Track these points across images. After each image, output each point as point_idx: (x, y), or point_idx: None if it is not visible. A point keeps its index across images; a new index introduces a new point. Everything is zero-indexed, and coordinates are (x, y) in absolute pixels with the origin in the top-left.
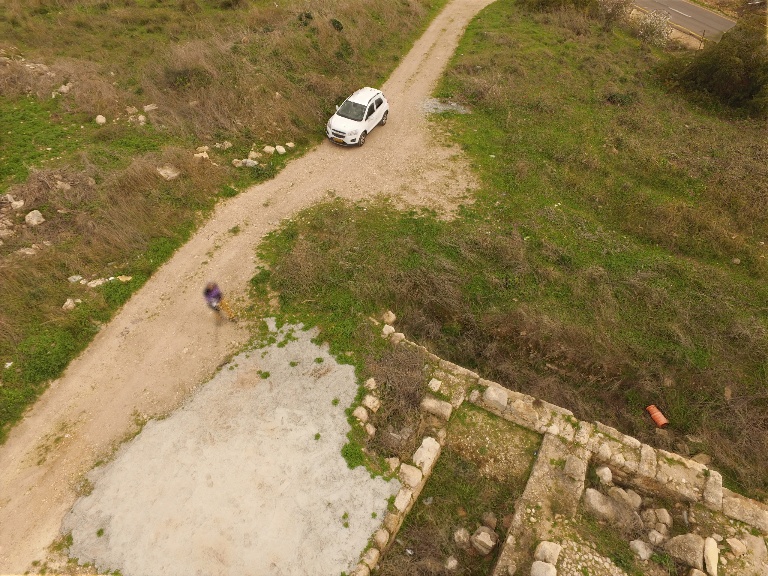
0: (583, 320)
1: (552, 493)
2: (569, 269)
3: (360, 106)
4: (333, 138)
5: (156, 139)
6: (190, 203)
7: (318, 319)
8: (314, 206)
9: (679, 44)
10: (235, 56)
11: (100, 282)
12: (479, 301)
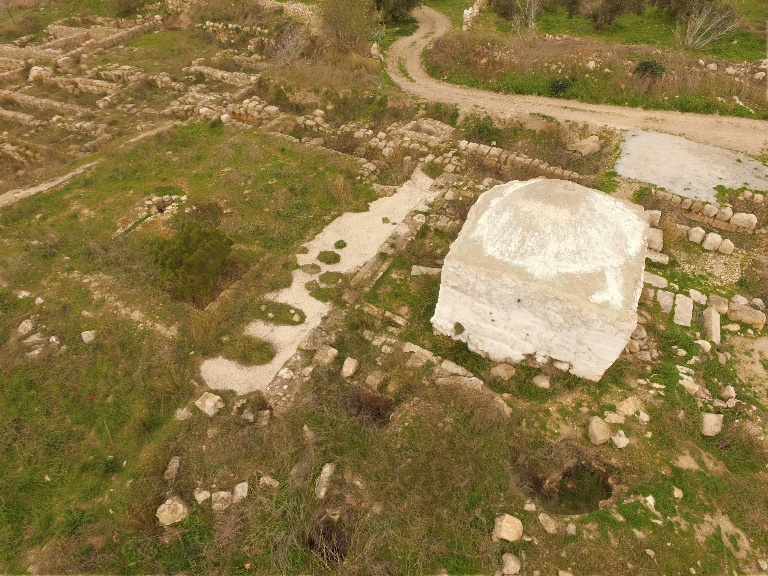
0: None
1: (764, 263)
2: None
3: None
4: None
5: None
6: None
7: None
8: None
9: None
10: None
11: (742, 104)
12: None
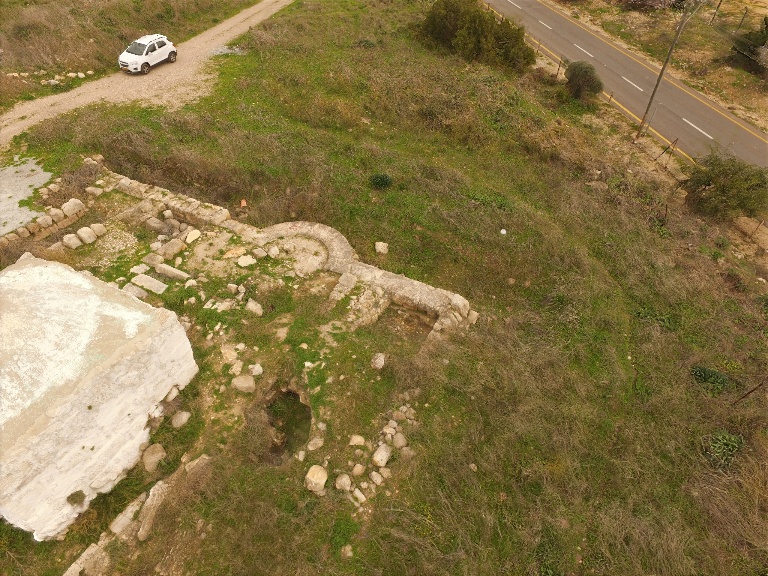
0: None
1: (127, 217)
2: None
3: (142, 45)
4: (122, 68)
5: None
6: None
7: None
8: (86, 106)
9: None
10: (72, 16)
11: None
12: None
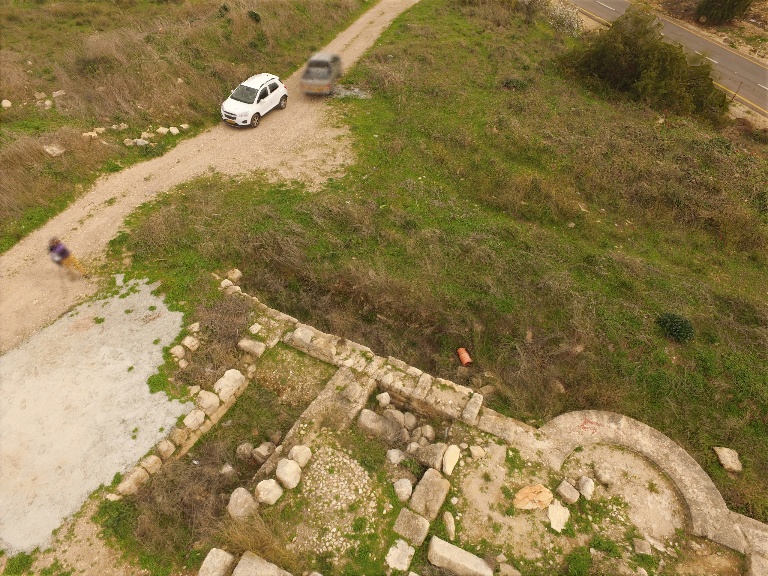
0: (411, 275)
1: (327, 412)
2: (413, 232)
3: (252, 90)
4: (226, 120)
5: (57, 121)
6: (71, 177)
7: (163, 275)
8: (193, 180)
9: (595, 35)
10: (147, 45)
11: None
12: (318, 259)
